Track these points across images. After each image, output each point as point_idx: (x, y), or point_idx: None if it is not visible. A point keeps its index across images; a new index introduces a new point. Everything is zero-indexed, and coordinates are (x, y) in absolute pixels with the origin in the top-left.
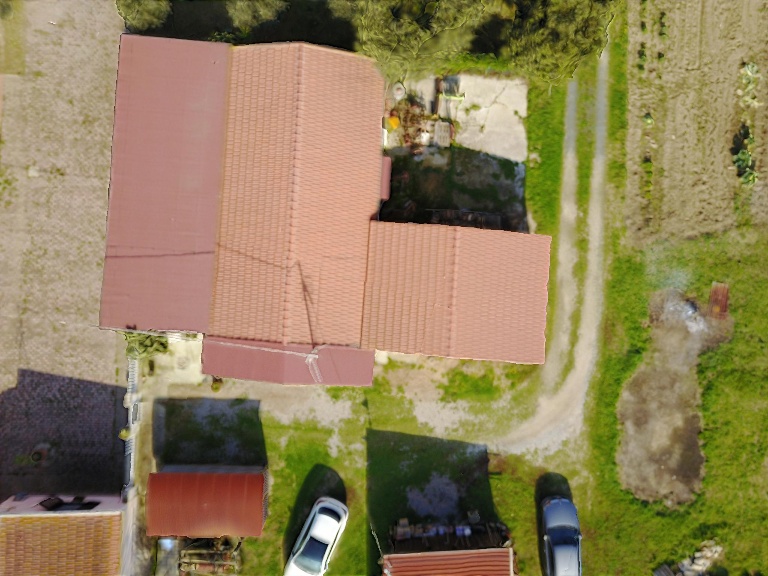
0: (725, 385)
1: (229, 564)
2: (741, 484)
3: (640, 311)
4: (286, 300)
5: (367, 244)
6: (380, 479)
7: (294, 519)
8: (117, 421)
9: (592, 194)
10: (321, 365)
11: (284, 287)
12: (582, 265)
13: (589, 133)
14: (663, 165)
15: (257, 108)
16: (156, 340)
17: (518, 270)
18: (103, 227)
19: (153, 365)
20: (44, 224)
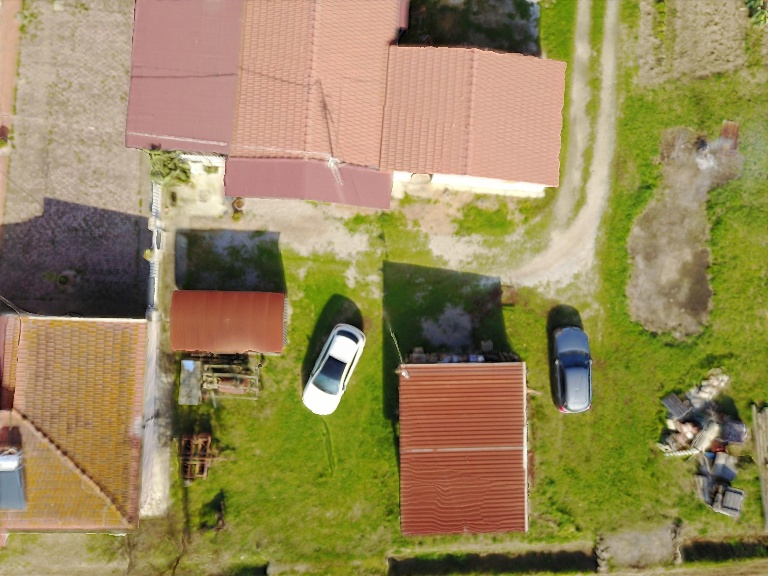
0: (734, 221)
1: (251, 377)
2: (748, 316)
3: (652, 148)
4: (308, 117)
5: (386, 69)
6: (396, 310)
7: (313, 347)
8: (141, 250)
9: (606, 34)
10: None
11: (306, 105)
12: (595, 103)
13: None
14: (676, 6)
15: None
16: (179, 166)
17: (534, 94)
18: (127, 62)
19: (176, 197)
20: (69, 57)
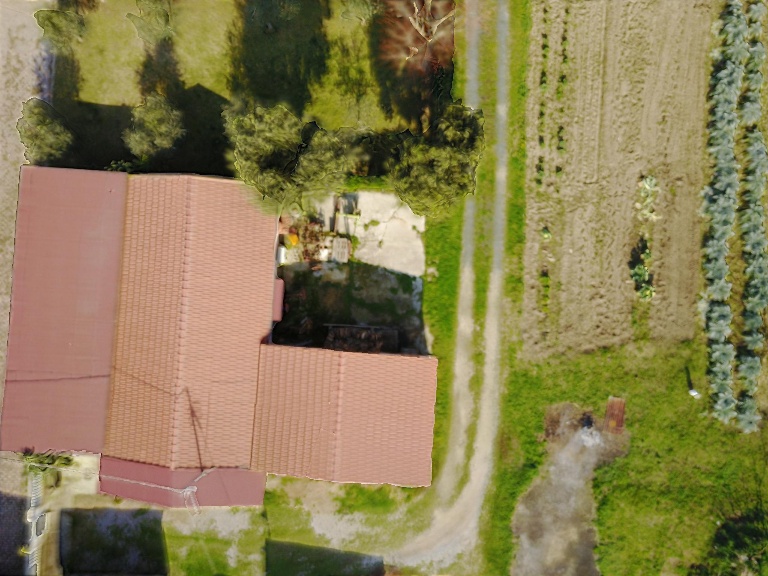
0: (621, 500)
1: None
2: None
3: (536, 425)
4: (174, 426)
5: (257, 367)
6: None
7: None
8: (26, 530)
9: (489, 308)
10: (211, 487)
11: (173, 413)
12: (479, 379)
13: (486, 247)
14: (560, 279)
15: (150, 236)
16: (59, 456)
17: (404, 394)
18: None
19: (61, 475)
20: None
